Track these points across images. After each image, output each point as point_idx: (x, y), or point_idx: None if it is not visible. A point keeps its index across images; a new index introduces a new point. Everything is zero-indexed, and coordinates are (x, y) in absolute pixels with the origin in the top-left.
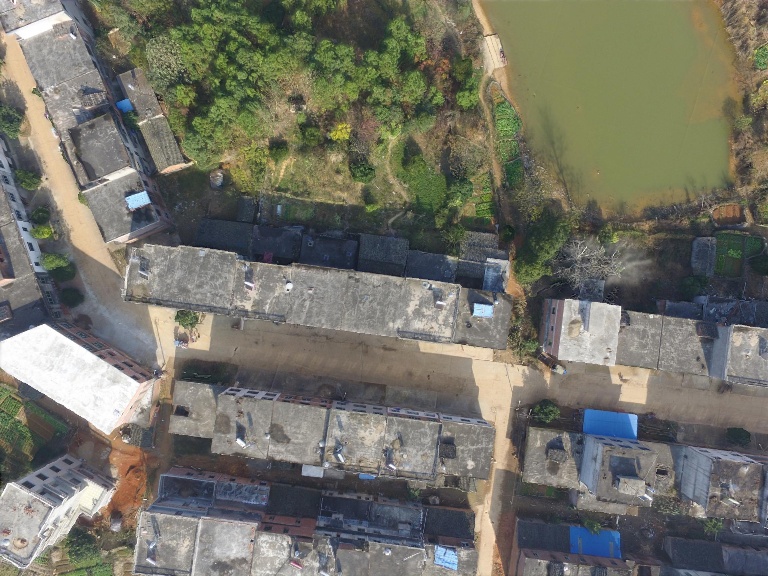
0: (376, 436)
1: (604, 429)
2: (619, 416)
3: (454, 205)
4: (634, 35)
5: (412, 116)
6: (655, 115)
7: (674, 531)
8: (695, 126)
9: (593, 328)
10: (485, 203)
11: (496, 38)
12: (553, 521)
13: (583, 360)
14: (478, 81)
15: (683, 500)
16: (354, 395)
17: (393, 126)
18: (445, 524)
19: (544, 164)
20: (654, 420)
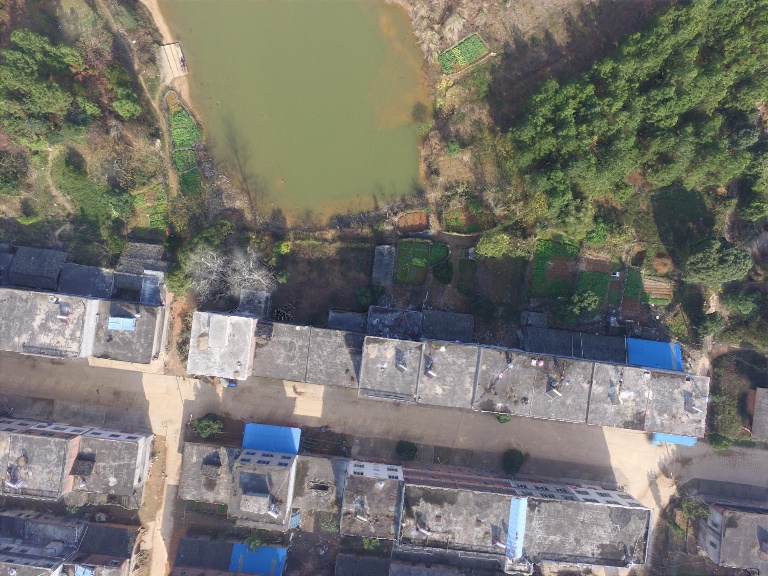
0: (0, 453)
1: (263, 444)
2: (281, 430)
3: (116, 216)
4: (320, 41)
5: (60, 127)
6: (343, 122)
7: (348, 548)
8: (384, 132)
9: (212, 341)
10: (159, 214)
11: (177, 47)
12: (218, 538)
13: (212, 374)
14: (153, 90)
15: (337, 516)
16: (21, 410)
17: (35, 138)
18: (104, 542)
19: (227, 173)
20: (330, 433)
